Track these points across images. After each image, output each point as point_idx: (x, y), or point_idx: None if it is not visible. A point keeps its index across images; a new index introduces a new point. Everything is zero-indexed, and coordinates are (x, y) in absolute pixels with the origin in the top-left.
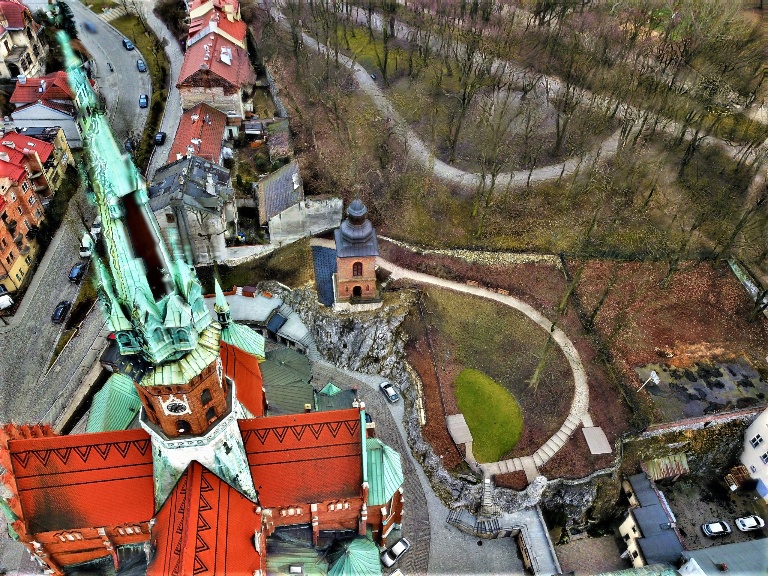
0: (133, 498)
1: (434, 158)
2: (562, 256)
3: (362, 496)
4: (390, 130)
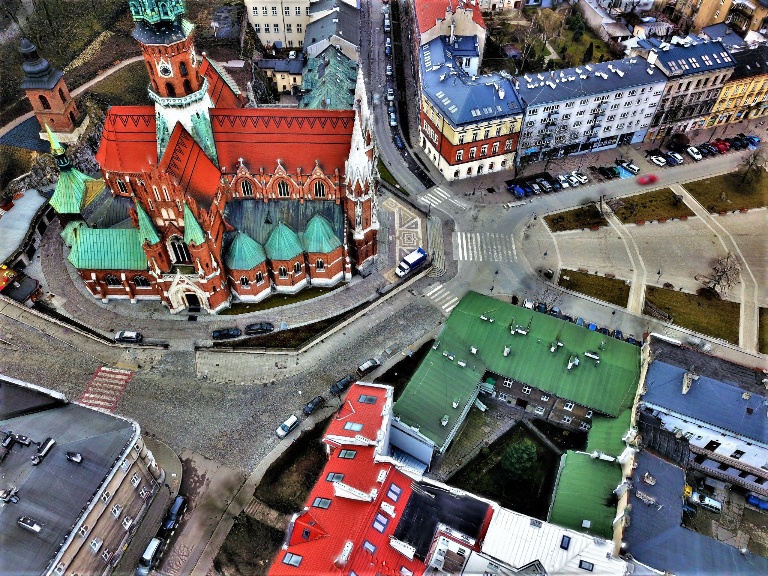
0: (207, 168)
1: None
2: (107, 29)
3: (242, 103)
4: None
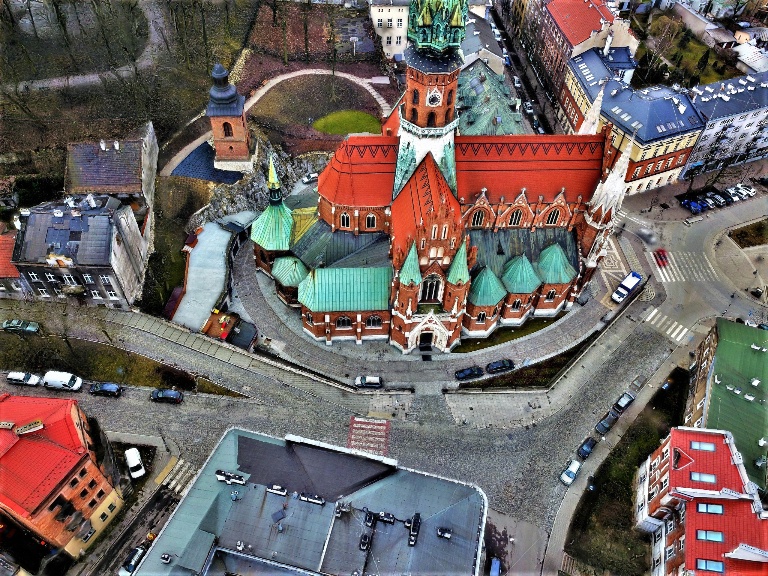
0: None
1: (105, 73)
2: None
3: None
4: (43, 90)
